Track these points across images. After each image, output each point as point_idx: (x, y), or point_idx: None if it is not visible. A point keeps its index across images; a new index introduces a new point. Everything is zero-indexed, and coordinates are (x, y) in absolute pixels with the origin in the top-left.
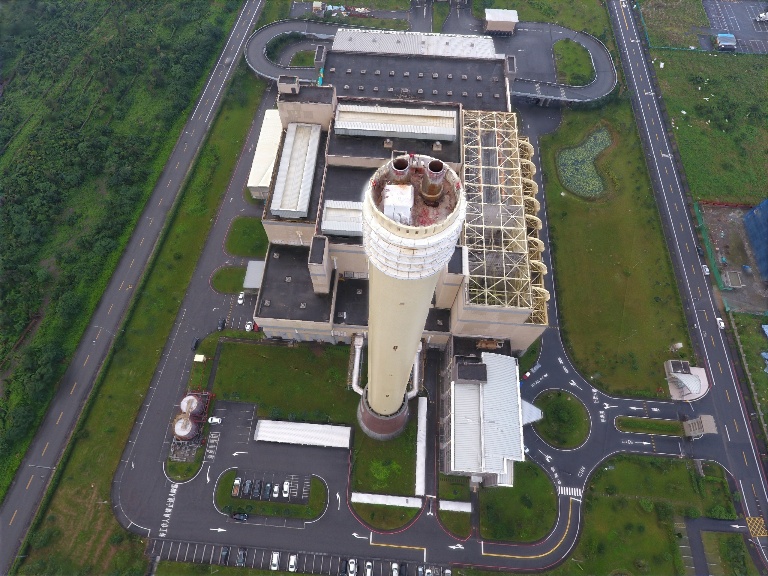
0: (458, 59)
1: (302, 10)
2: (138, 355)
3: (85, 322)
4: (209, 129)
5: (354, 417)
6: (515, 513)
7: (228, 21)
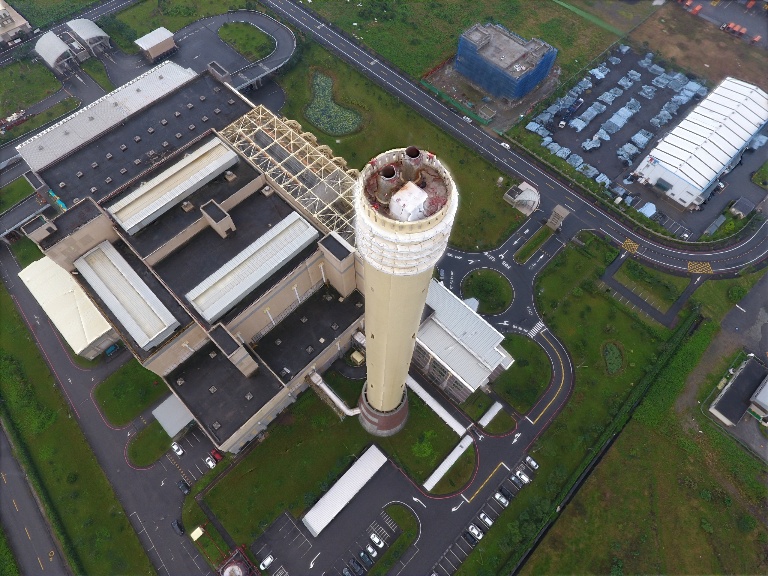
0: (169, 95)
1: None
2: None
3: None
4: None
5: (367, 435)
6: (524, 377)
7: None
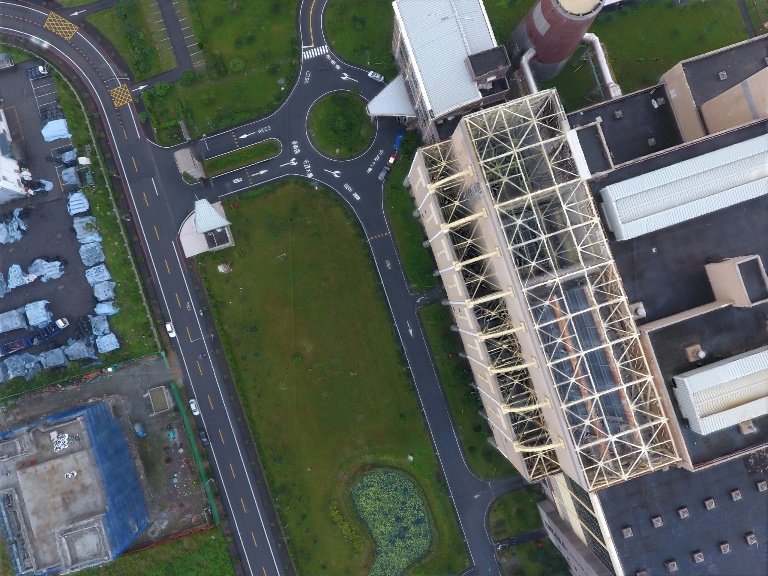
0: None
1: None
2: None
3: None
4: None
5: None
6: (367, 7)
7: None
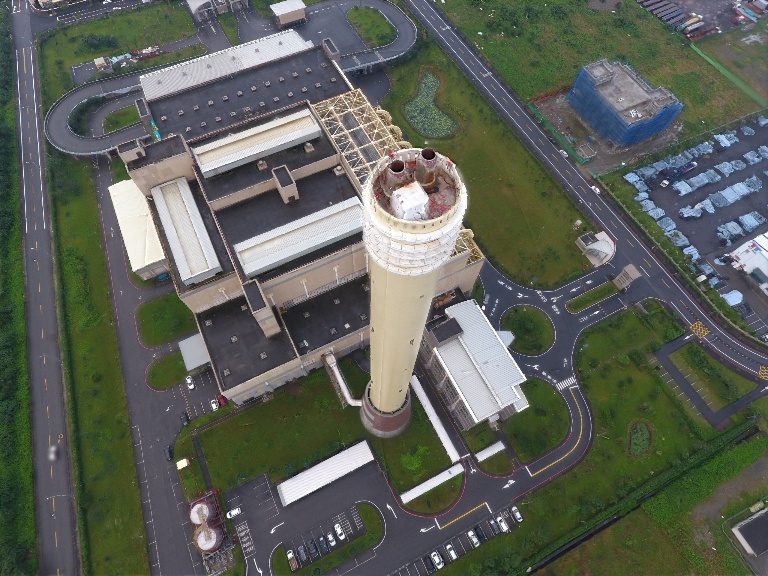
0: (279, 60)
1: (86, 73)
2: (113, 500)
3: (30, 502)
4: (54, 234)
5: (362, 429)
6: (537, 427)
7: (8, 115)
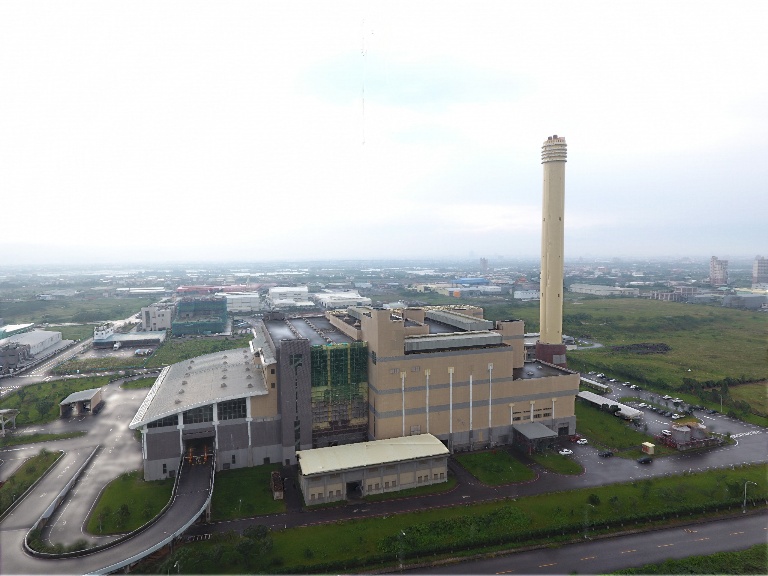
0: None
1: None
2: None
3: None
4: (352, 560)
5: None
6: None
7: None
